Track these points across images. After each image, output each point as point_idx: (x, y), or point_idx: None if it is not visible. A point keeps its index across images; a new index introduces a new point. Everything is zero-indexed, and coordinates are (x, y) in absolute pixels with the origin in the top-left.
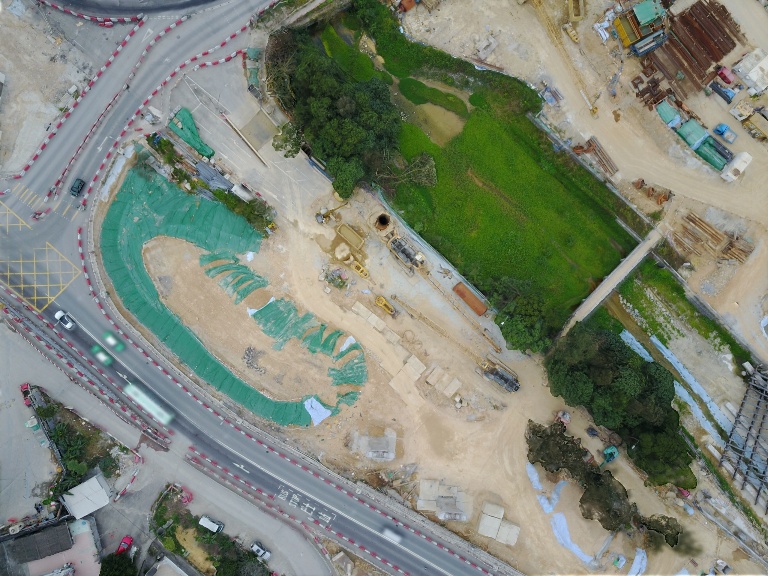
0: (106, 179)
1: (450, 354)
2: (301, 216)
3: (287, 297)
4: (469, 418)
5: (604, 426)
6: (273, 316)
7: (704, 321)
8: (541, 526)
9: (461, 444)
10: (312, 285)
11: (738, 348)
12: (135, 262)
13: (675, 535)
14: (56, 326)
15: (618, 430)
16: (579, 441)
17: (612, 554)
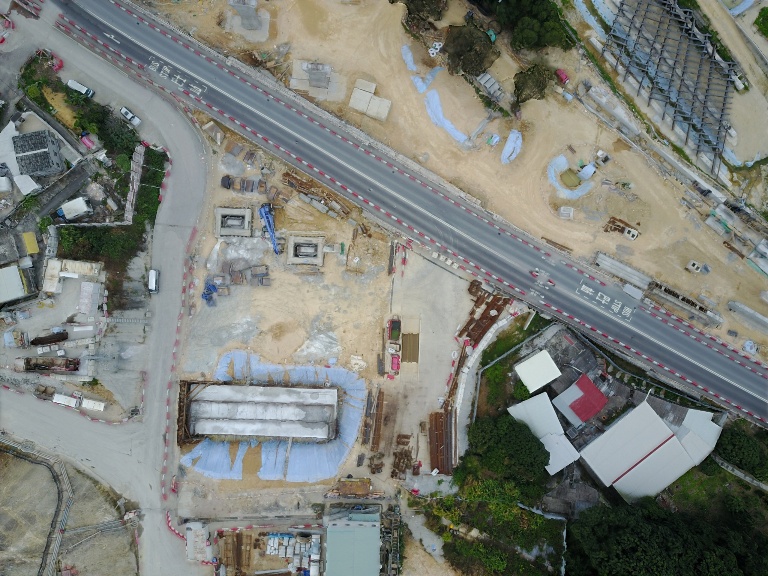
0: None
1: None
2: None
3: None
4: (343, 0)
5: (482, 12)
6: None
7: None
8: (415, 106)
9: (335, 25)
10: None
11: None
12: None
13: (542, 90)
14: None
15: (491, 0)
16: None
17: (486, 134)
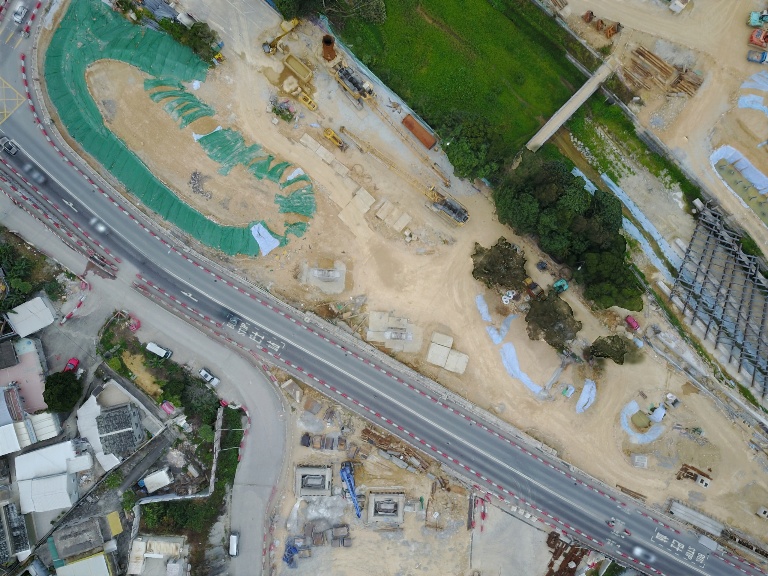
0: (50, 7)
1: (400, 189)
2: (249, 48)
3: (234, 127)
4: (419, 251)
5: (554, 260)
6: (219, 143)
7: (654, 158)
8: (490, 357)
9: (411, 276)
10: (260, 117)
11: (688, 184)
12: (79, 87)
13: (621, 355)
14: (0, 153)
15: (566, 258)
16: (522, 253)
17: (561, 384)
